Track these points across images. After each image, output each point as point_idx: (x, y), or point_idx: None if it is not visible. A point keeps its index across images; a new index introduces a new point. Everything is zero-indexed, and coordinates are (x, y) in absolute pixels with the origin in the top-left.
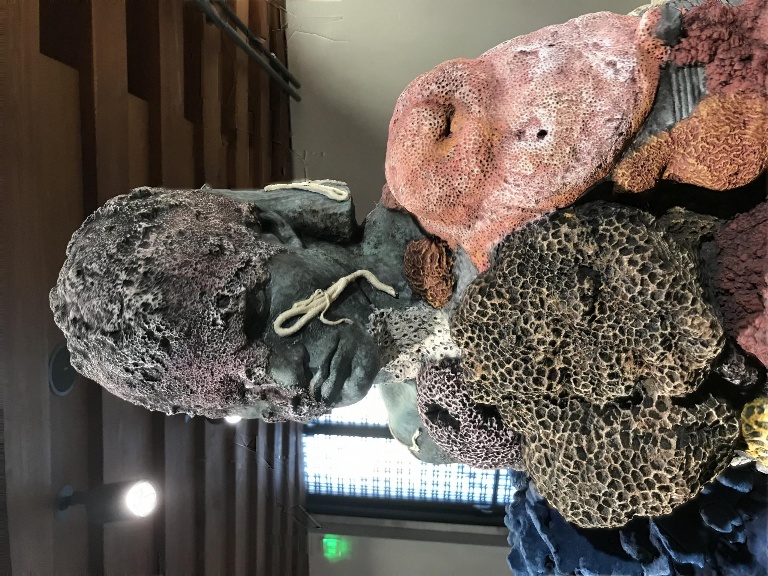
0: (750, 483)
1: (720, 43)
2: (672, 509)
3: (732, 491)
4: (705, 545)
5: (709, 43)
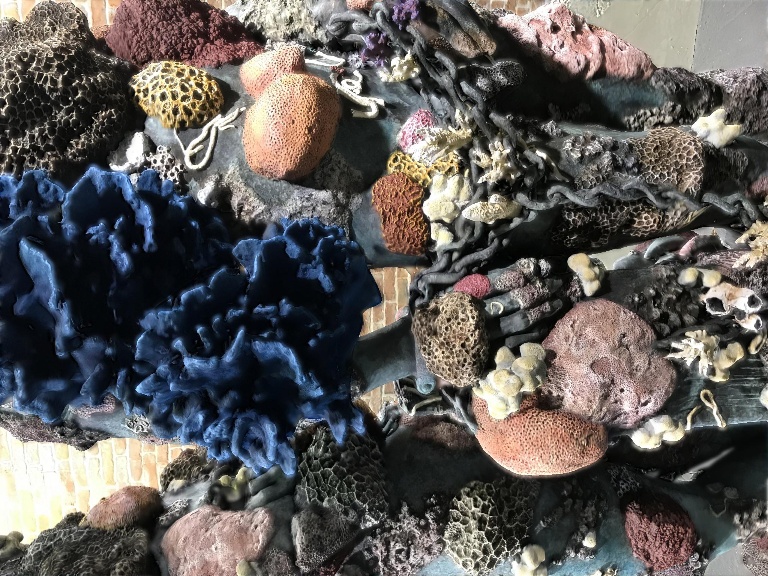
0: None
1: None
2: (57, 62)
3: None
4: None
5: None
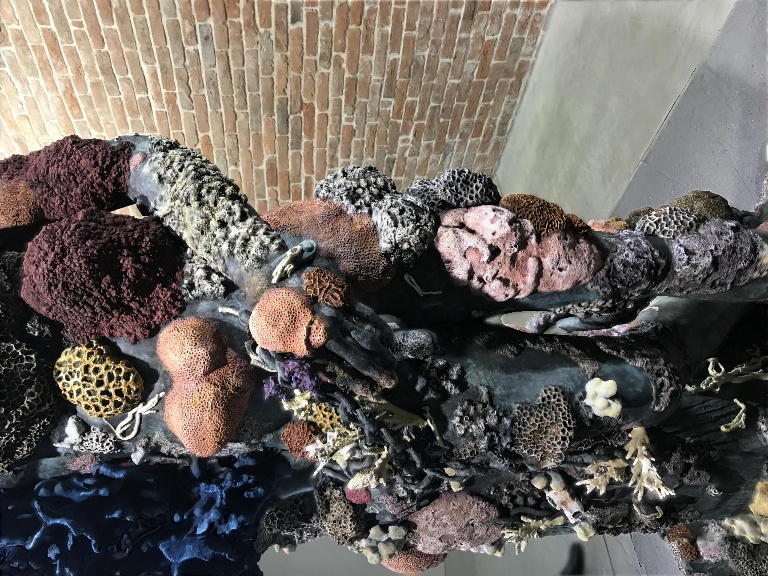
0: (125, 470)
1: (9, 164)
2: None
3: (114, 481)
4: (91, 528)
5: (2, 163)
